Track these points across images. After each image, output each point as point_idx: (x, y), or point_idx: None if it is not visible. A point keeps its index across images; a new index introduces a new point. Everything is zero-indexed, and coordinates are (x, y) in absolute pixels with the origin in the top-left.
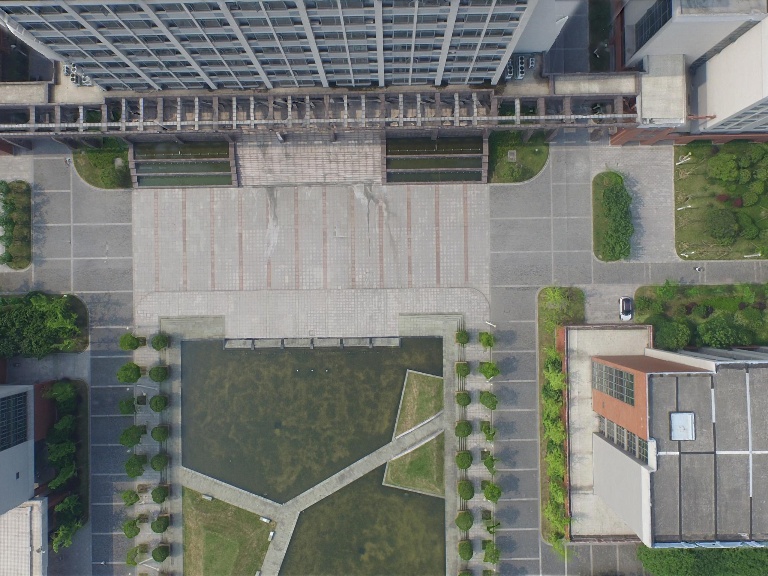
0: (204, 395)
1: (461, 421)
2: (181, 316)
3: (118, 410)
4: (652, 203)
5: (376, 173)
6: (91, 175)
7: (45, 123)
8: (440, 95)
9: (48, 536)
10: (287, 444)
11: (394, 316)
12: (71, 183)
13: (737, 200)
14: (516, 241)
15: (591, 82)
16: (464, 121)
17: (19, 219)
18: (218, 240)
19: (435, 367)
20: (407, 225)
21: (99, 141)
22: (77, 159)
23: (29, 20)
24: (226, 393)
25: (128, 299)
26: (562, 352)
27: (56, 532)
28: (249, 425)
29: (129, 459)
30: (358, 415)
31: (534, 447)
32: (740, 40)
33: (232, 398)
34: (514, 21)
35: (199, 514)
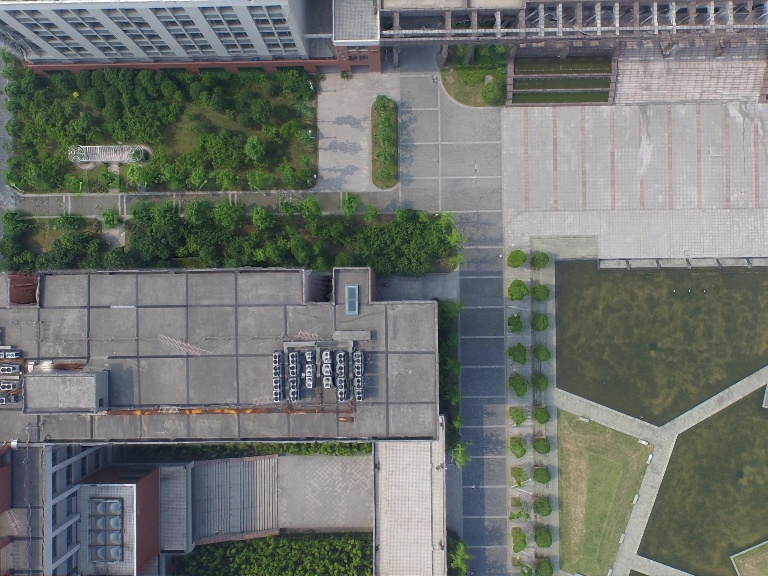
0: (577, 316)
1: None
2: (553, 236)
3: (488, 331)
4: None
5: (755, 90)
6: (460, 93)
7: (462, 29)
8: None
9: (446, 453)
10: (663, 366)
11: None
12: (439, 101)
13: None
14: None
15: None
16: None
17: None
18: (589, 159)
19: None
20: None
21: (470, 58)
22: (445, 77)
23: None
24: (600, 314)
25: (497, 219)
26: None
27: (455, 449)
28: (624, 346)
29: (517, 378)
30: (735, 336)
31: None
32: None
33: (606, 319)
34: None
35: (578, 436)
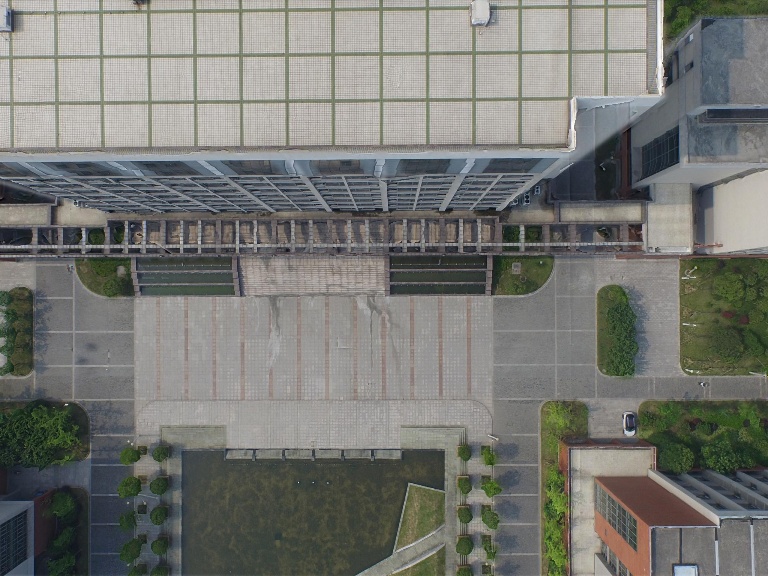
0: (205, 505)
1: (462, 536)
2: (182, 425)
3: (118, 519)
4: (657, 317)
5: (379, 285)
6: (93, 283)
7: (48, 244)
8: (444, 221)
9: None
10: (287, 556)
11: (396, 428)
12: (73, 290)
13: (743, 317)
14: (519, 354)
15: (597, 209)
16: (468, 237)
17: (21, 326)
18: (220, 349)
19: (437, 480)
20: (410, 336)
21: None
22: (80, 266)
23: (31, 183)
24: (227, 504)
25: (129, 407)
26: (565, 471)
27: None
28: (249, 536)
29: (129, 573)
30: (359, 527)
31: (535, 561)
32: (748, 179)
33: (233, 509)
34: (520, 183)
35: None
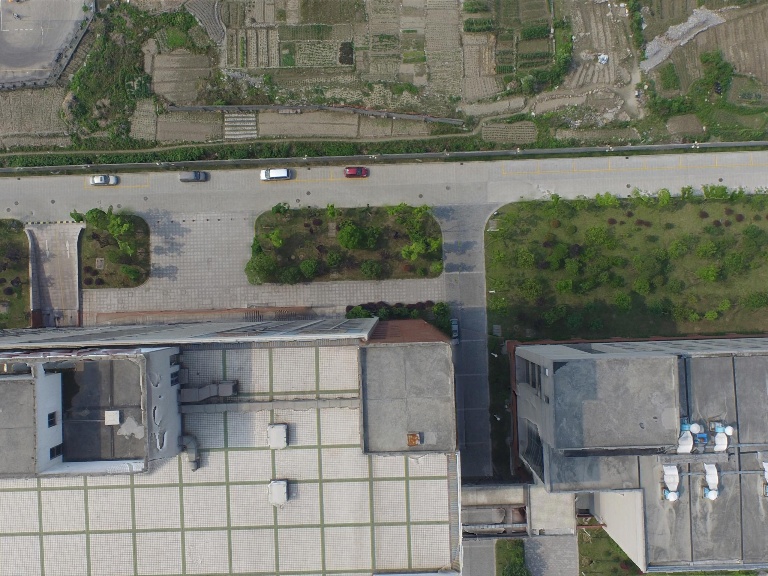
0: None
1: None
2: None
3: None
4: (556, 565)
5: None
6: None
7: None
8: None
9: None
10: None
11: None
12: None
13: None
14: None
15: (479, 493)
16: None
17: None
18: None
19: None
20: None
21: None
22: None
23: None
24: None
25: None
26: None
27: None
28: None
29: None
30: None
31: None
32: None
33: None
34: None
35: None
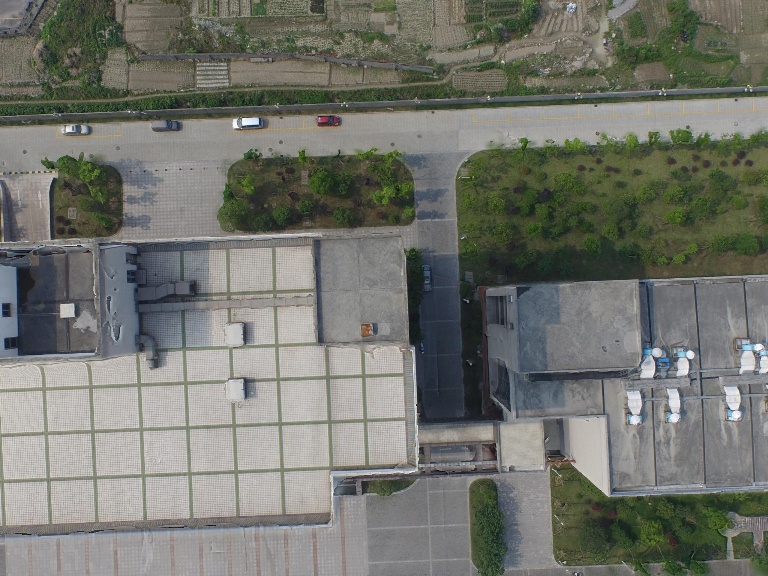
0: None
1: None
2: None
3: None
4: (529, 509)
5: None
6: None
7: None
8: None
9: None
10: None
11: None
12: None
13: (611, 510)
14: (394, 551)
15: (450, 430)
16: None
17: None
18: (93, 558)
19: None
20: (284, 538)
21: None
22: None
23: None
24: None
25: None
26: None
27: None
28: None
29: None
30: None
31: None
32: None
33: None
34: None
35: None
